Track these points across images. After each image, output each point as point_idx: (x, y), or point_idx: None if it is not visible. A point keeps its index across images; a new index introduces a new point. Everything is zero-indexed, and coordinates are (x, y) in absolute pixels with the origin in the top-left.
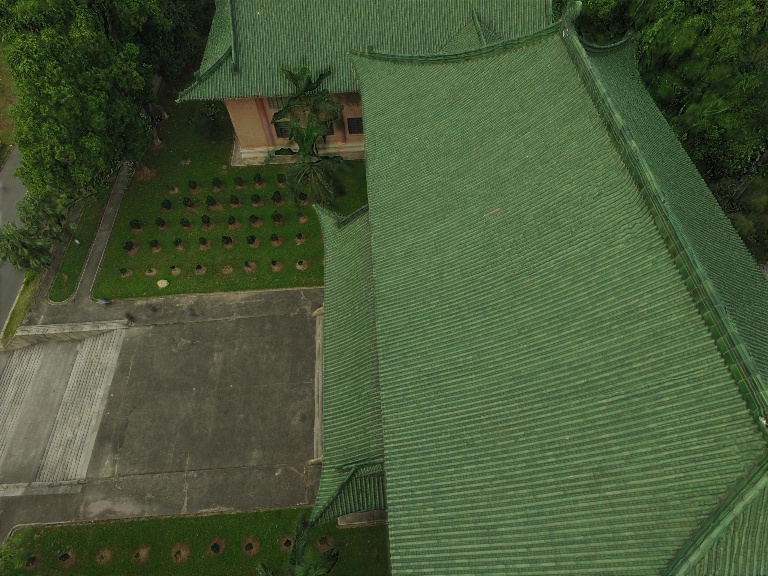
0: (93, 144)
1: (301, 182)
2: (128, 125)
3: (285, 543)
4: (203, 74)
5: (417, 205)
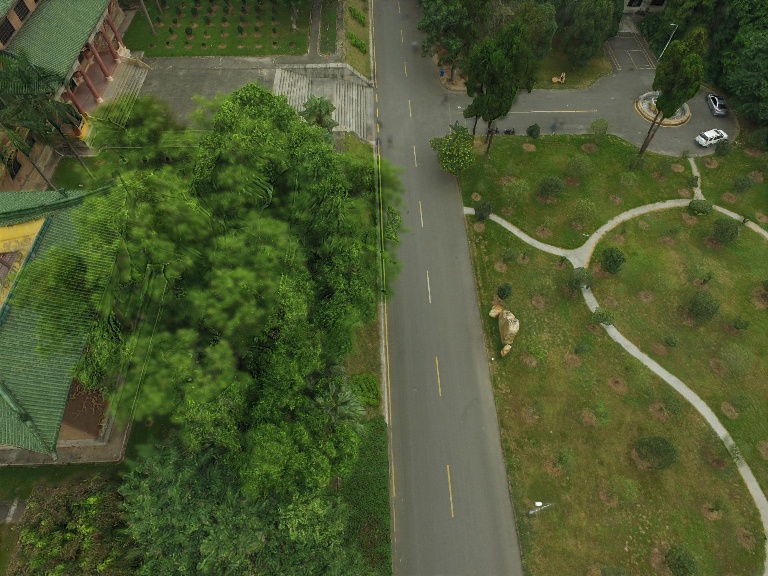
0: None
1: None
2: (225, 184)
3: (168, 42)
4: (106, 187)
5: None
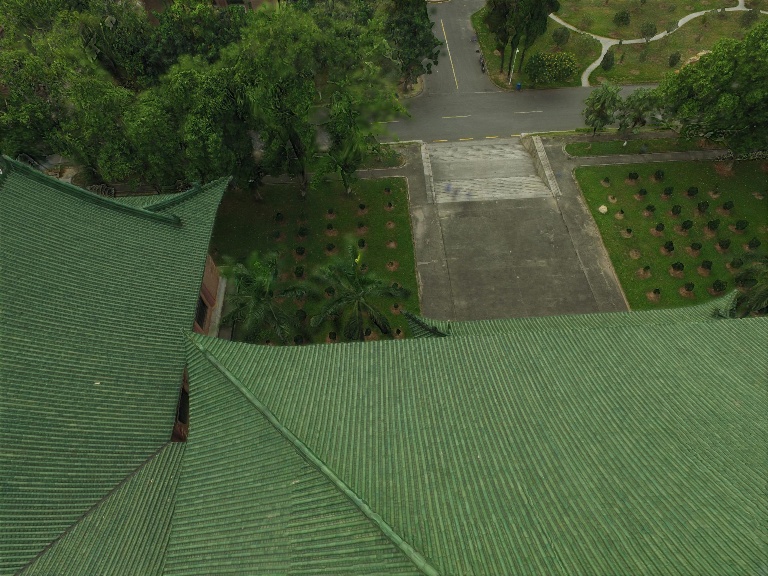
0: (725, 102)
1: (765, 273)
2: None
3: None
4: None
5: (764, 359)
